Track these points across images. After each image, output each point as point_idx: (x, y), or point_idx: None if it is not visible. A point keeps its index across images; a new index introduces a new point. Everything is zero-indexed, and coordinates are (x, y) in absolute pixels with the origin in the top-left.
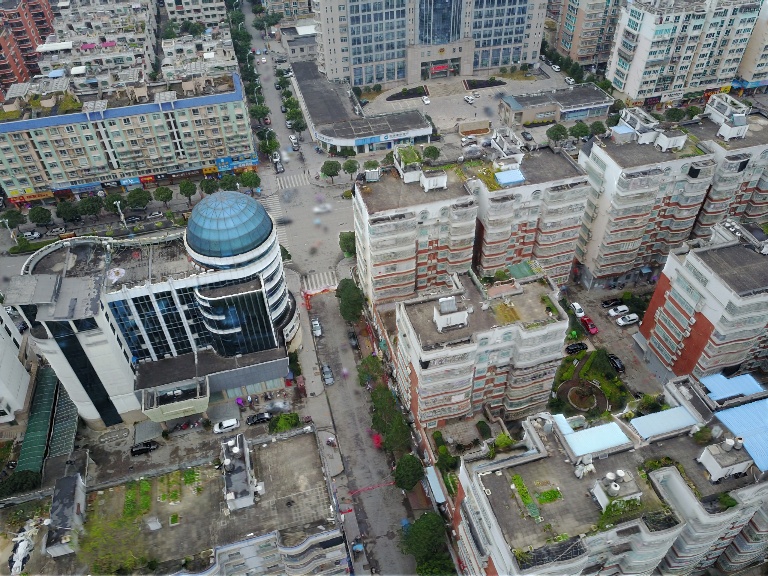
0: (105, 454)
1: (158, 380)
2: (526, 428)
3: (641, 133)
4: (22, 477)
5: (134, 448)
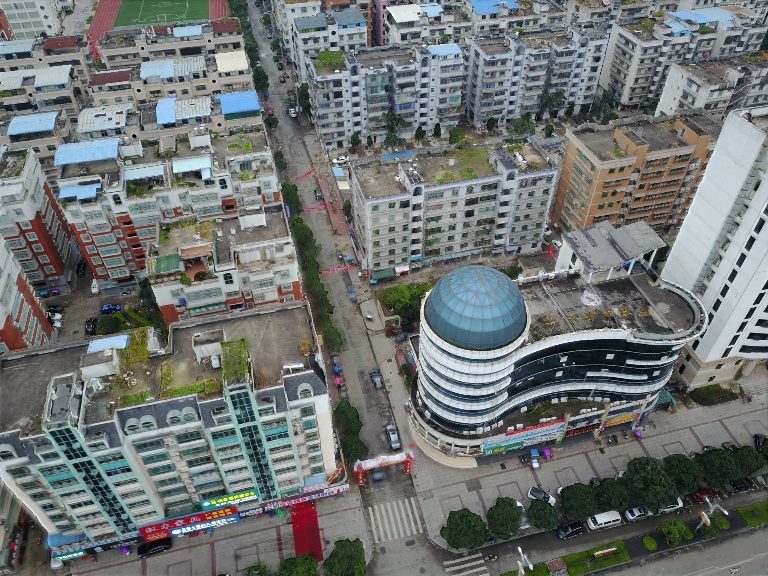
0: None
1: None
2: None
3: None
4: None
5: None
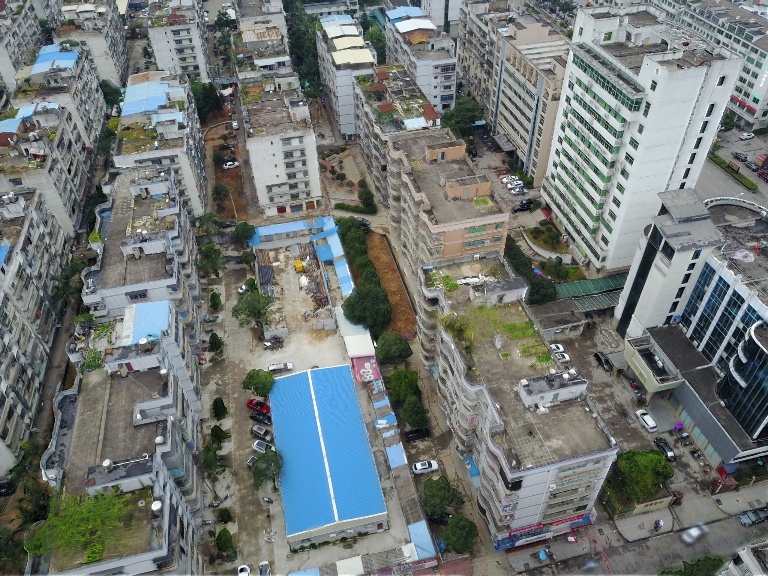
0: (591, 337)
1: (665, 343)
2: None
3: None
4: (548, 285)
5: (600, 353)
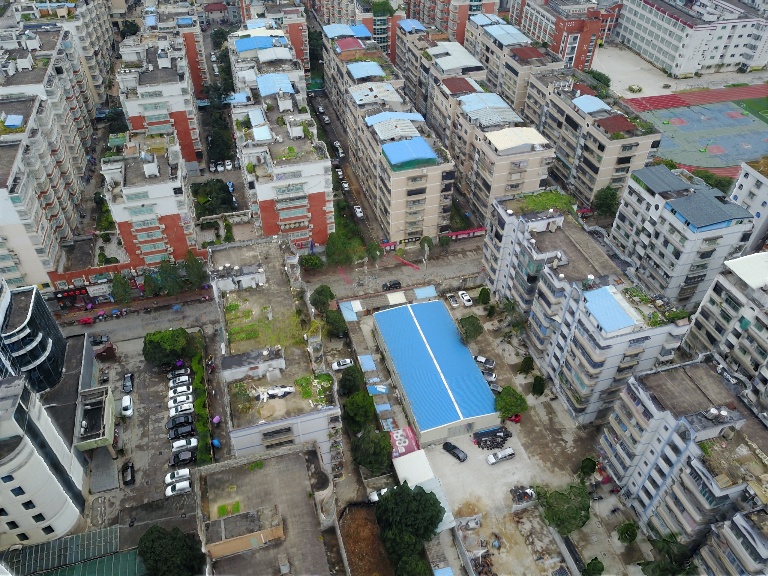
0: None
1: (64, 437)
2: (248, 154)
3: (7, 67)
4: None
5: (127, 479)
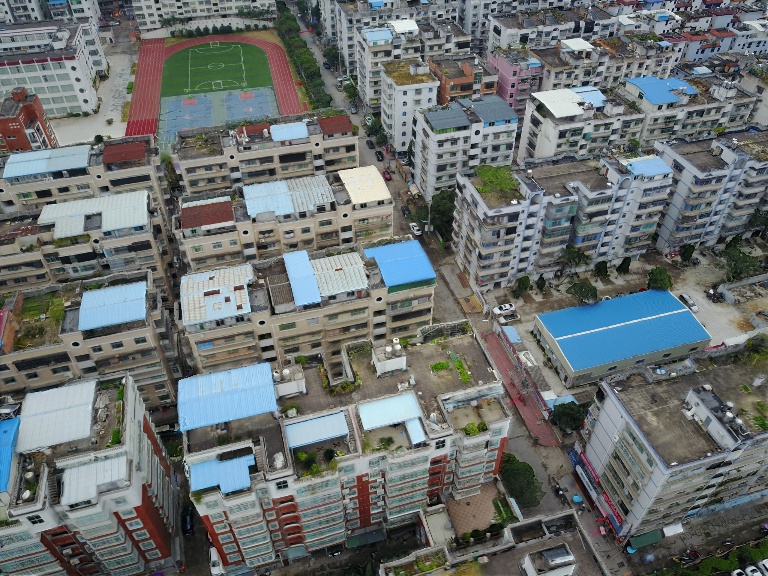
0: None
1: None
2: None
3: None
4: None
5: None
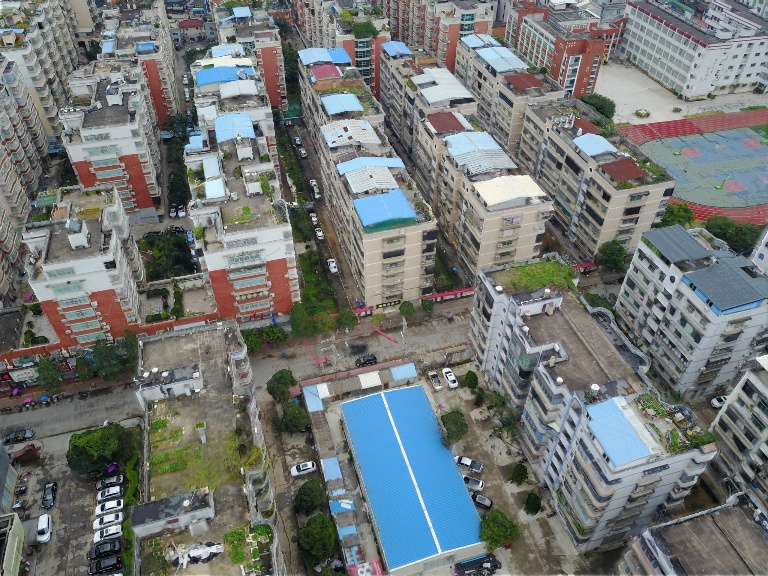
0: None
1: None
2: (196, 216)
3: None
4: None
5: None
